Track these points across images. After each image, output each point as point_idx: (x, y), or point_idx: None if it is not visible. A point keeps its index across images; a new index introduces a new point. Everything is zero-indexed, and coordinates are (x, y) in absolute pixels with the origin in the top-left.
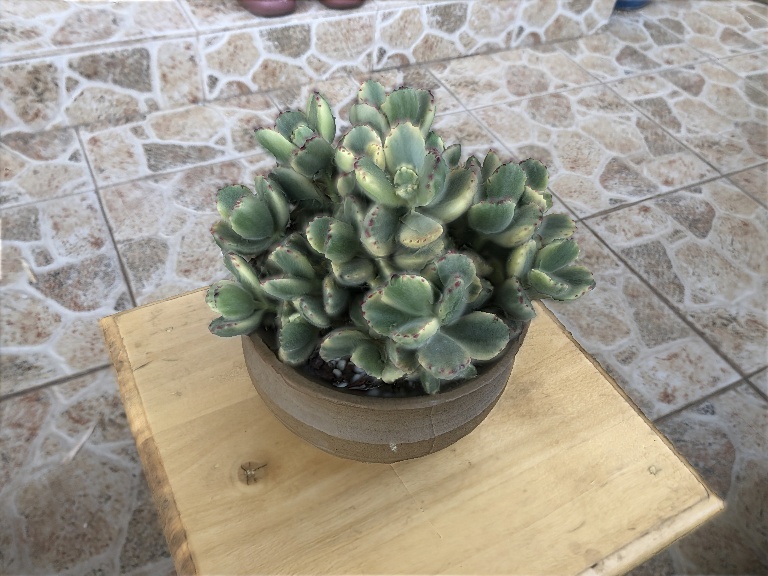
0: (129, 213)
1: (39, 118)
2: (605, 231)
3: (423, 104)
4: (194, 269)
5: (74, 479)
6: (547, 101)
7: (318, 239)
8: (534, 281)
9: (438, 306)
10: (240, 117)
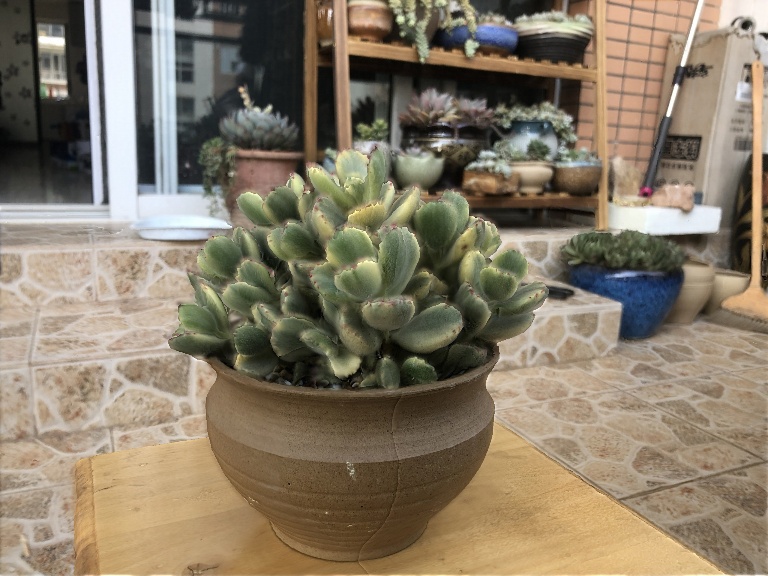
0: None
1: (79, 417)
2: (647, 510)
3: (384, 188)
4: None
5: None
6: (568, 404)
7: (277, 242)
8: (484, 280)
9: None
10: None
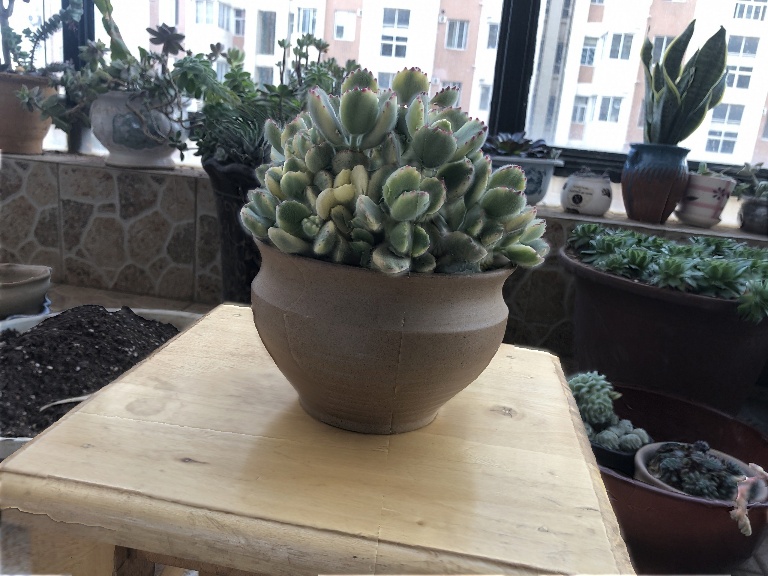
0: None
1: None
2: None
3: None
4: None
5: None
6: None
7: None
8: None
9: None
10: None
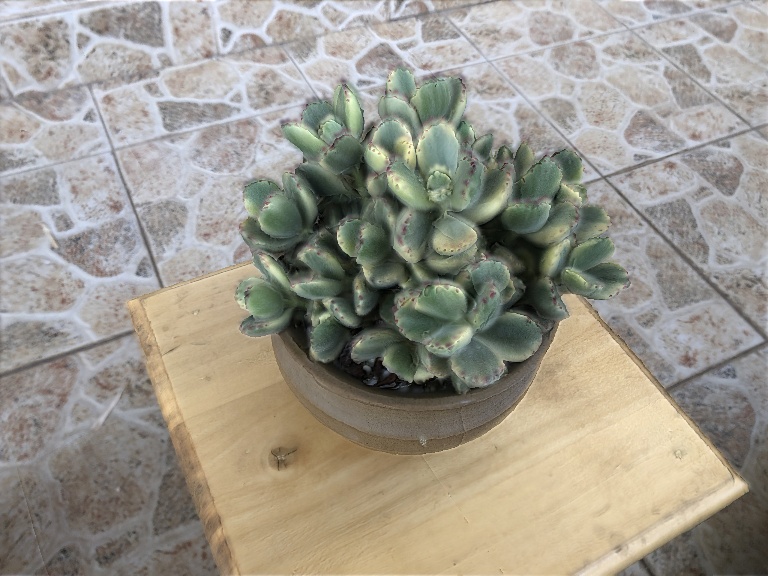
0: (146, 175)
1: (52, 77)
2: (629, 189)
3: (454, 94)
4: (213, 233)
5: (105, 444)
6: (571, 50)
7: (349, 243)
8: (568, 282)
9: (472, 315)
10: (255, 72)
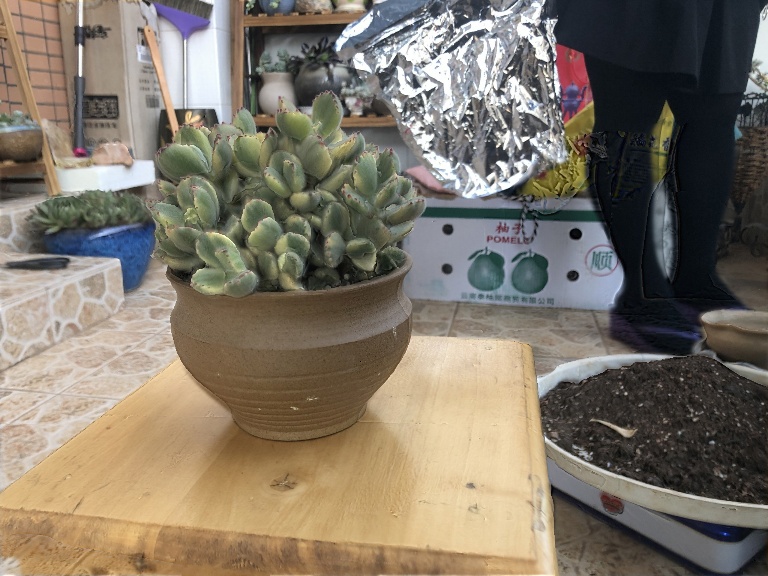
0: None
1: None
2: None
3: None
4: None
5: None
6: (124, 360)
7: (278, 179)
8: None
9: (385, 175)
10: None
